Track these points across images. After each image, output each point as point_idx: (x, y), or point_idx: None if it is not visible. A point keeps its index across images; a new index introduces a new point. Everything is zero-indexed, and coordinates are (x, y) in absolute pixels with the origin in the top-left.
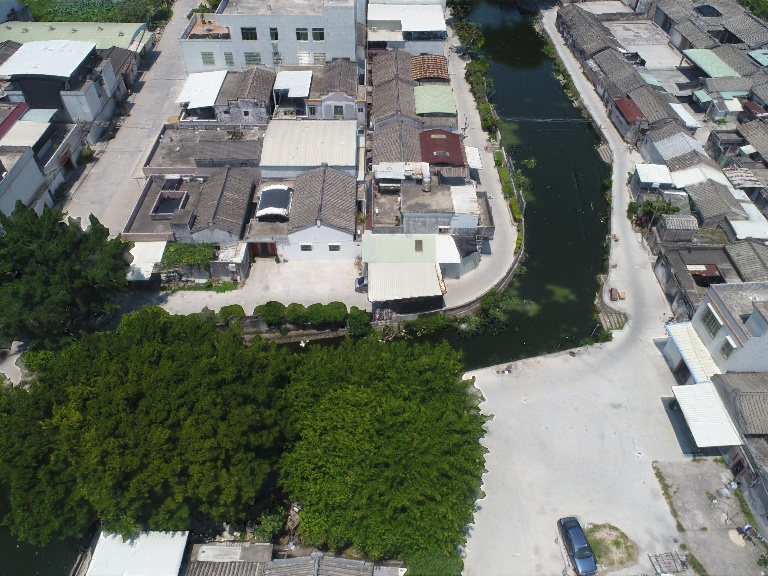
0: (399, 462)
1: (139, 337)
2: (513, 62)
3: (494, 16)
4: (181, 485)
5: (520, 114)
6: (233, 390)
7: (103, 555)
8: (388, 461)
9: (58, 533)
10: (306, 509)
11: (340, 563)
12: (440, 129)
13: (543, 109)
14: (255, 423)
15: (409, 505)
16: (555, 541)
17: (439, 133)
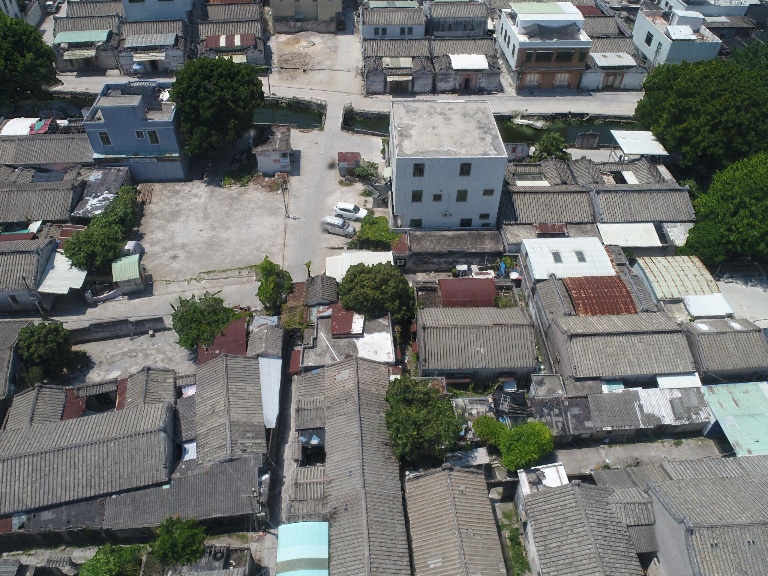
0: (764, 193)
1: (759, 73)
2: None
3: None
4: (692, 117)
5: None
6: (756, 111)
7: (642, 134)
8: (761, 184)
9: (643, 118)
10: (708, 194)
11: (688, 202)
12: None
13: None
14: (743, 128)
15: (739, 194)
16: (767, 327)
17: None
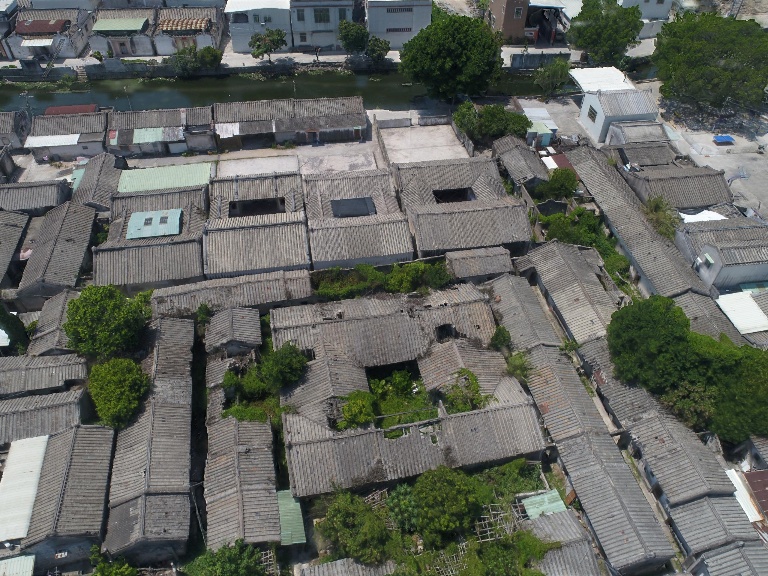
0: None
1: None
2: (271, 94)
3: (407, 89)
4: None
5: (150, 91)
6: None
7: None
8: None
9: None
10: None
11: None
12: (63, 22)
13: (155, 101)
14: None
15: None
16: None
17: (57, 21)
